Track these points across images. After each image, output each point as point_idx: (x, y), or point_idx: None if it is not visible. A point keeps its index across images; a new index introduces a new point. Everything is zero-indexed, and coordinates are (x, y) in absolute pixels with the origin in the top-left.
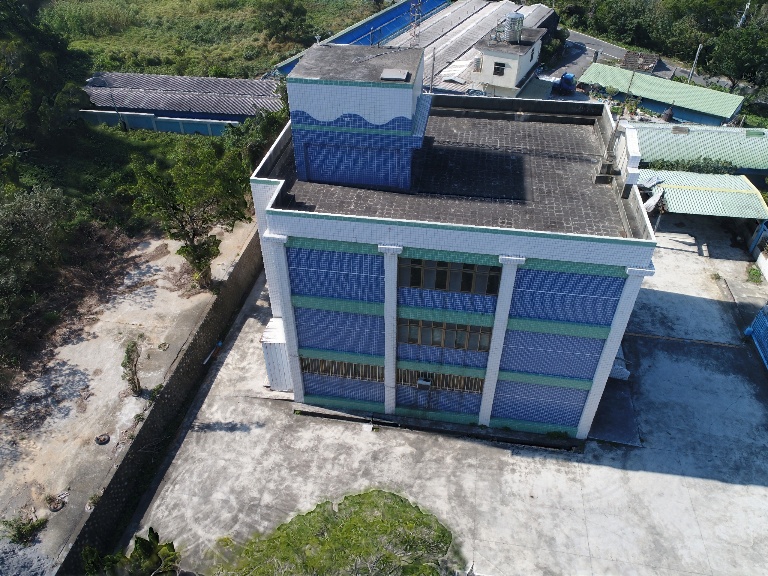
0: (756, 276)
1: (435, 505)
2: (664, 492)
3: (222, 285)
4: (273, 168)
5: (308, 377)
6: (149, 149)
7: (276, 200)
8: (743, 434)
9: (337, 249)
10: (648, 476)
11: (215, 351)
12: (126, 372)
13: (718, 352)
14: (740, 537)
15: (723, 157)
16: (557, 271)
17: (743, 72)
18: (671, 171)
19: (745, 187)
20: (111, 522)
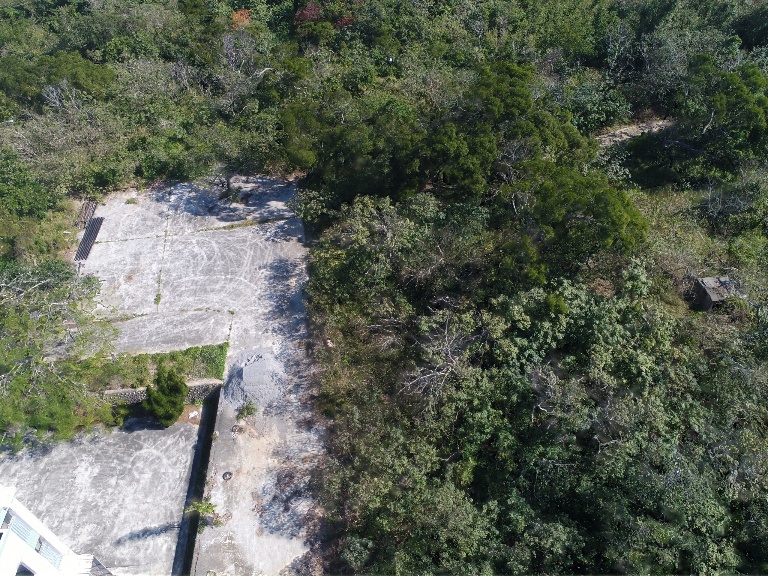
0: None
1: None
2: None
3: None
4: None
5: None
6: None
7: None
8: None
9: None
10: None
11: None
12: None
13: None
14: None
15: None
16: None
17: None
18: None
19: None
20: None
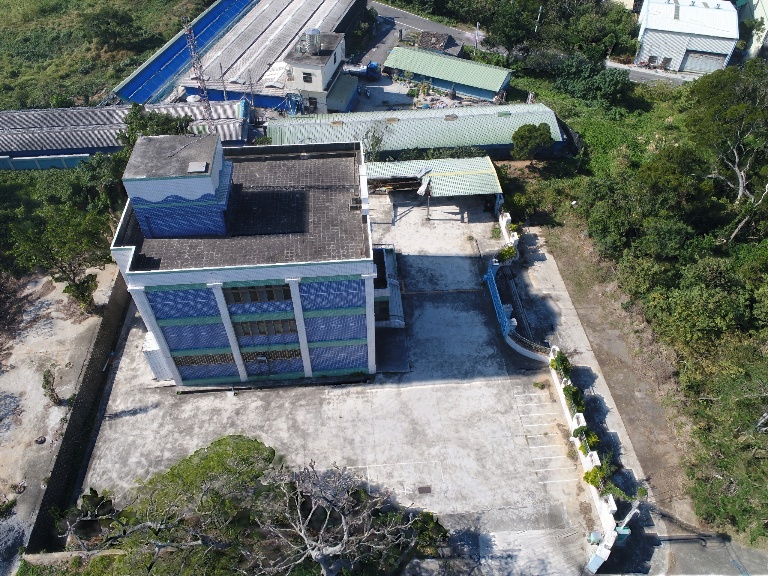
0: (497, 233)
1: (279, 435)
2: (421, 397)
3: (105, 308)
4: (126, 232)
5: (182, 368)
6: (13, 191)
7: (132, 264)
8: (473, 351)
9: (180, 289)
10: (413, 389)
11: (110, 360)
12: (46, 391)
13: (465, 296)
14: (462, 415)
15: (481, 137)
16: (323, 281)
17: (513, 43)
18: (438, 159)
19: (487, 168)
20: (61, 492)
